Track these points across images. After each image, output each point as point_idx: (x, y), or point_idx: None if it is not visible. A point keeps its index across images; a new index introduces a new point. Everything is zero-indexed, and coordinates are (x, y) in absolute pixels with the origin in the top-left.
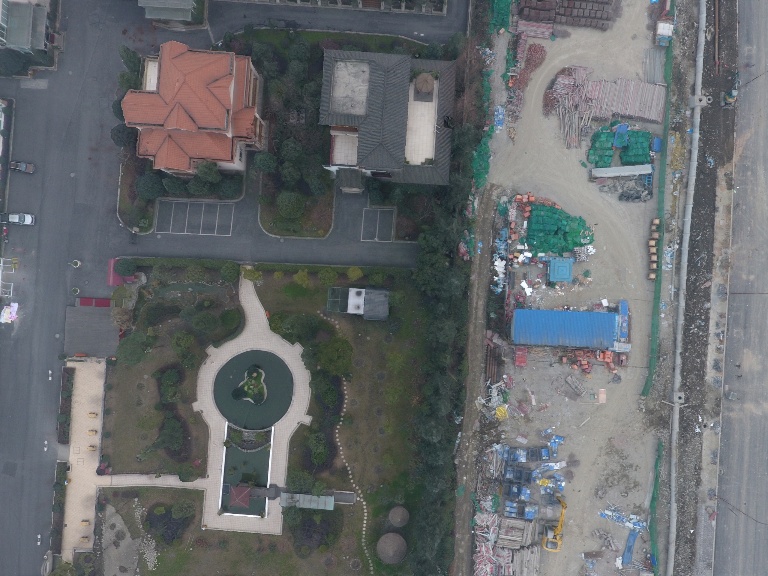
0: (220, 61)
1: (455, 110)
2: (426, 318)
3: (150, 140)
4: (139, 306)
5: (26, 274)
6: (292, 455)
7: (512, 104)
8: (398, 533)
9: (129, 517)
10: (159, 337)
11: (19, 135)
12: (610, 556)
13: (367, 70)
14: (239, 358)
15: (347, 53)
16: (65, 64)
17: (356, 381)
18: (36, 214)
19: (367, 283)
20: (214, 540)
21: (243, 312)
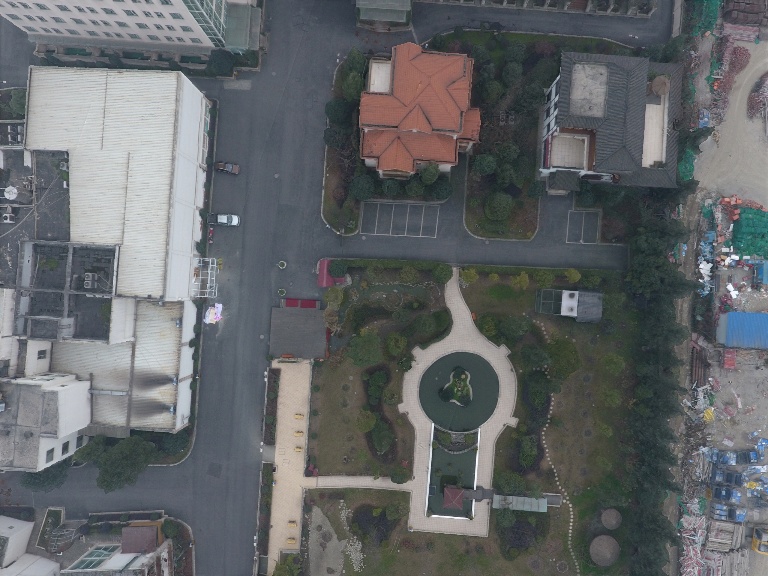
0: (457, 63)
1: (682, 113)
2: (632, 320)
3: (378, 142)
4: (344, 307)
5: (230, 275)
6: (498, 457)
7: (718, 107)
8: None
9: (335, 518)
10: None
11: (223, 136)
12: None
13: (605, 73)
14: (444, 360)
15: (585, 55)
16: (269, 65)
17: None
18: (241, 215)
19: (580, 285)
20: (421, 542)
21: (451, 314)
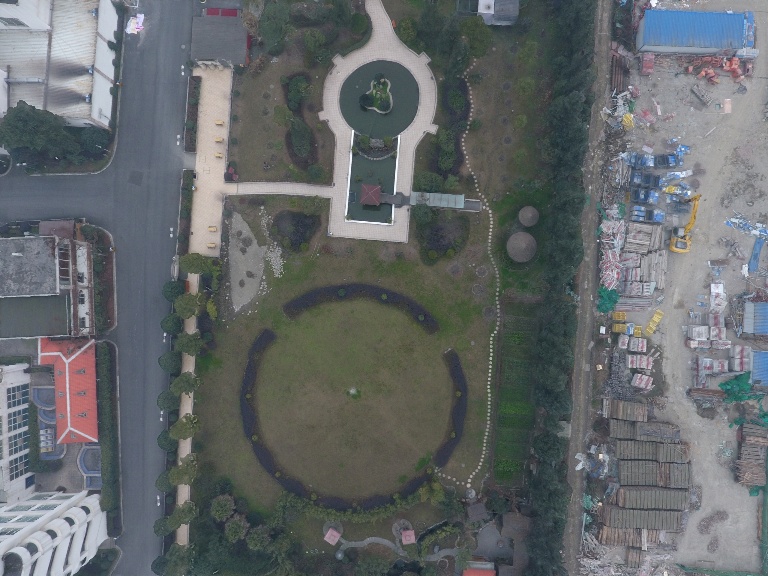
0: None
1: None
2: (552, 29)
3: None
4: None
5: None
6: (418, 164)
7: None
8: (527, 233)
9: (255, 224)
10: None
11: None
12: (736, 264)
13: None
14: (365, 69)
15: None
16: None
17: (482, 91)
18: None
19: None
20: (340, 247)
21: (370, 19)
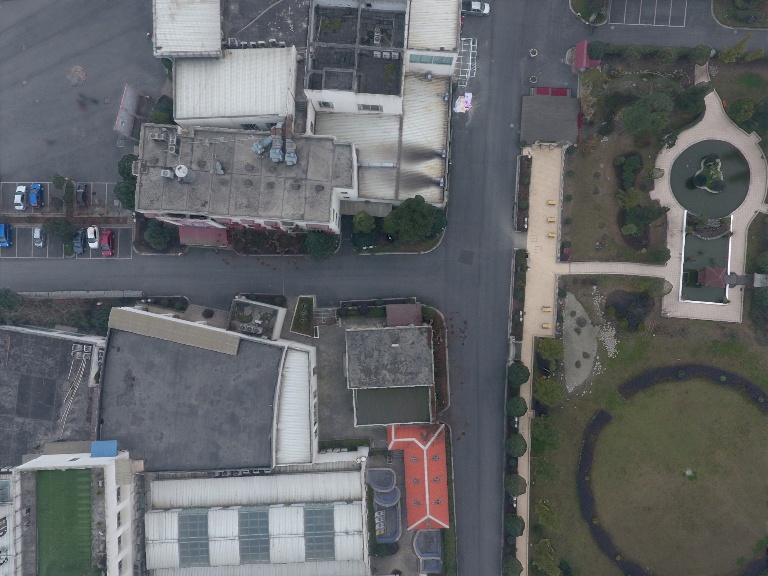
0: None
1: None
2: None
3: None
4: (593, 96)
5: (480, 65)
6: (750, 244)
7: None
8: None
9: (589, 304)
10: (616, 126)
11: None
12: None
13: None
14: (694, 148)
15: None
16: None
17: None
18: (490, 5)
19: None
20: (675, 327)
21: None
